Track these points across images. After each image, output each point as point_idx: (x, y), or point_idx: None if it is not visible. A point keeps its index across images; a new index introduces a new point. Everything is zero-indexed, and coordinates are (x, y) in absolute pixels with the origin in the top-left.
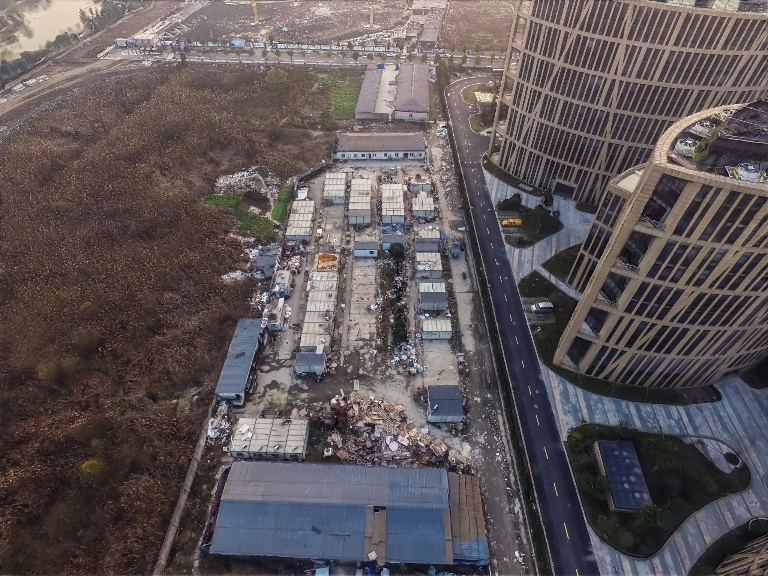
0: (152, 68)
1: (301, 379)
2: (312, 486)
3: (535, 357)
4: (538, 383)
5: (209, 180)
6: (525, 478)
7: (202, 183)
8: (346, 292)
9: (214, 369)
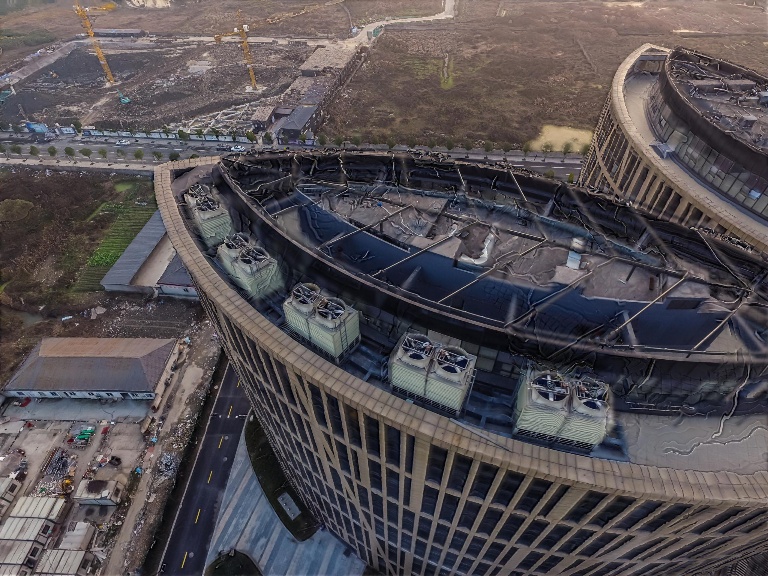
0: None
1: None
2: None
3: None
4: None
5: None
6: None
7: None
8: None
9: None
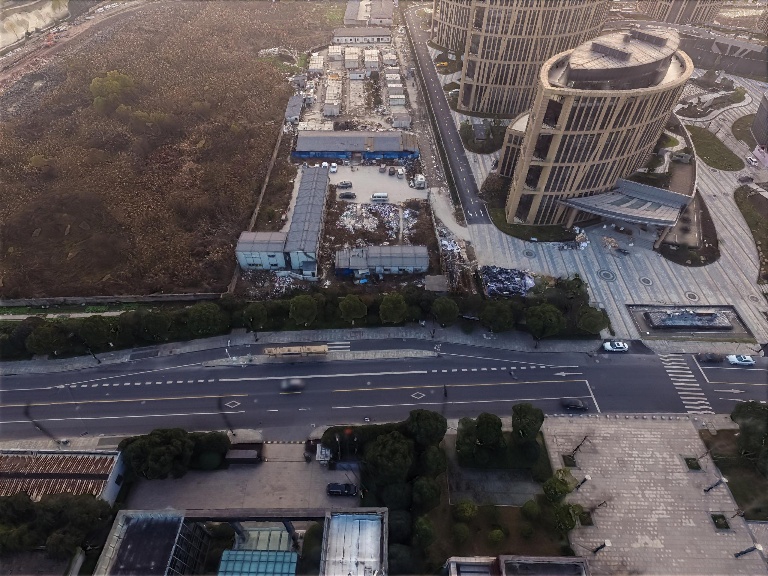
0: (192, 0)
1: (327, 117)
2: (339, 134)
3: (448, 108)
4: (449, 115)
5: (255, 50)
6: (437, 135)
7: (250, 52)
8: (347, 91)
9: (280, 115)
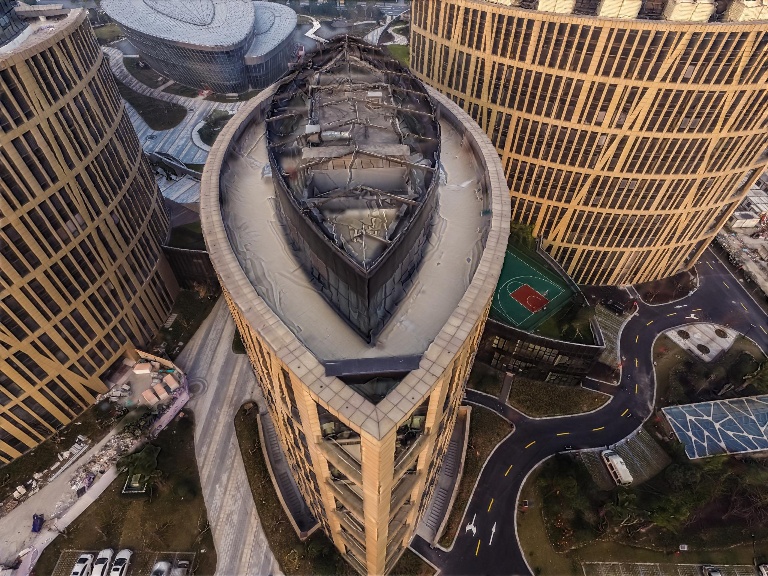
0: None
1: None
2: None
3: None
4: None
5: None
6: None
7: None
8: None
9: None
